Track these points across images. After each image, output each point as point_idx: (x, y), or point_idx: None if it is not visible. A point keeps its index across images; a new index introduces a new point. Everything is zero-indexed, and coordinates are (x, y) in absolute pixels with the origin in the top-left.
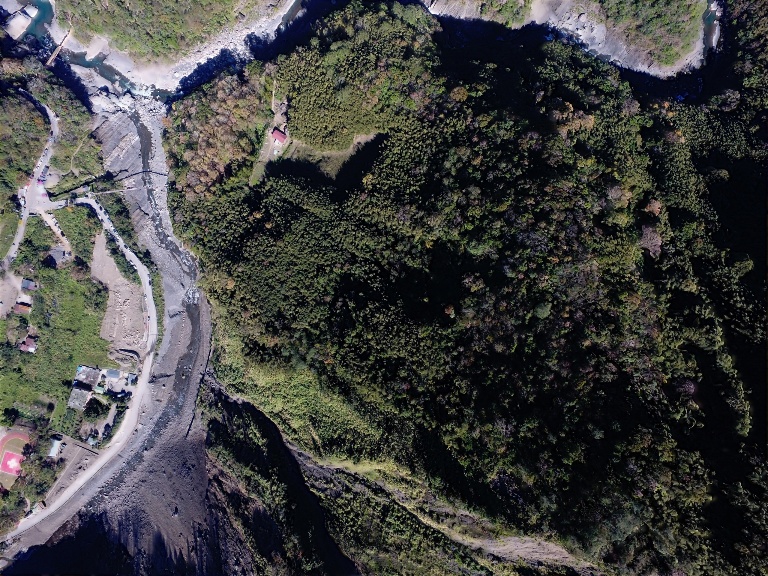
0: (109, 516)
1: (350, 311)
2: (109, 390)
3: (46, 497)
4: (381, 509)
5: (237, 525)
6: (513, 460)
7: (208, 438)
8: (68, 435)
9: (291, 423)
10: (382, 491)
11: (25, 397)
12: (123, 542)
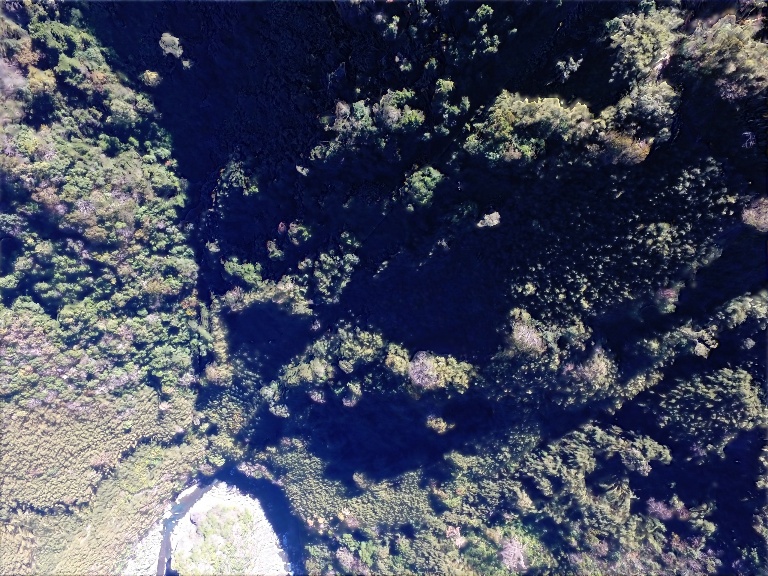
0: None
1: None
2: None
3: None
4: None
5: None
6: None
7: None
8: None
9: None
10: None
11: None
12: None
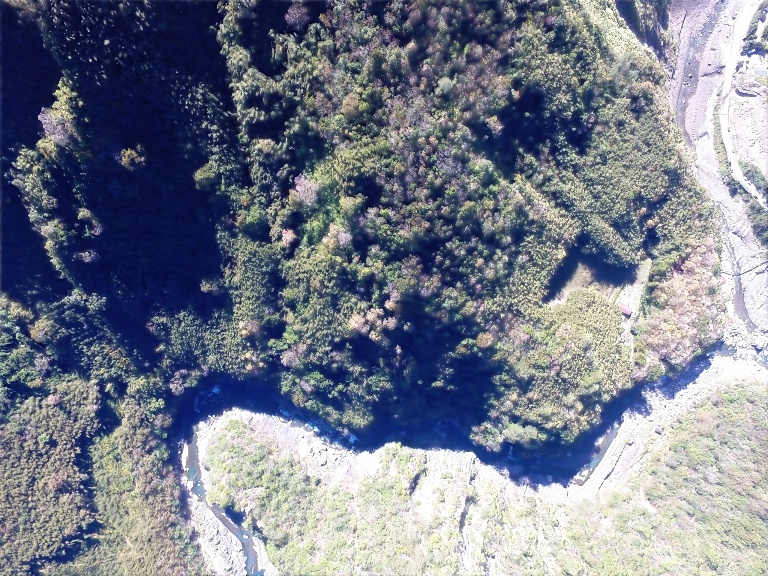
0: None
1: None
2: (763, 56)
3: None
4: None
5: None
6: None
7: None
8: None
9: None
10: None
11: None
12: None
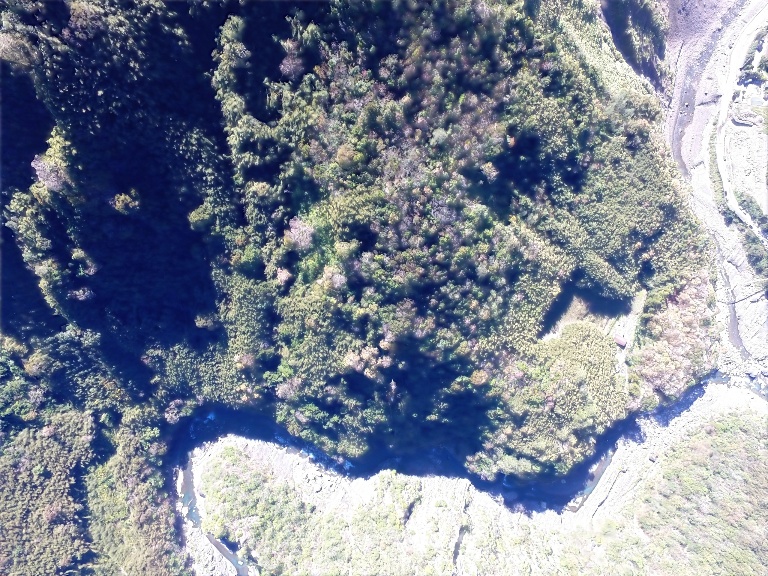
0: None
1: None
2: (760, 86)
3: None
4: None
5: None
6: None
7: None
8: None
9: None
10: None
11: None
12: None
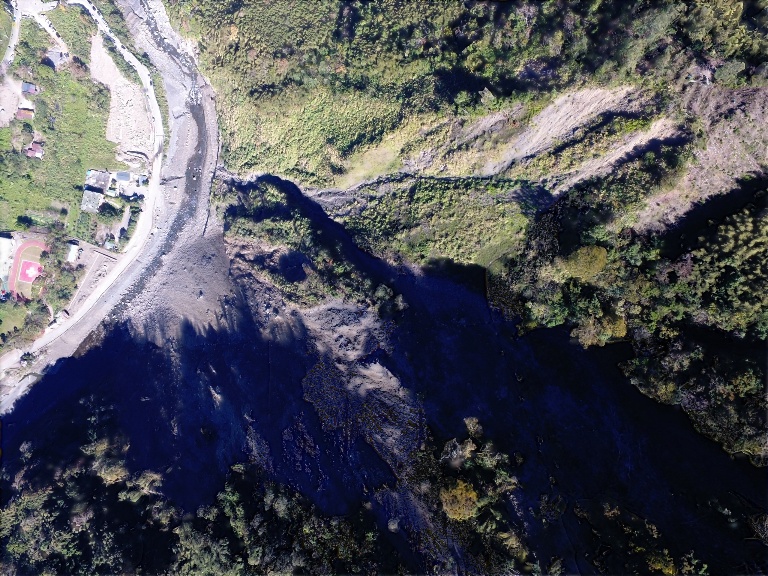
0: (134, 322)
1: (358, 11)
2: (121, 194)
3: (68, 306)
4: (408, 193)
5: (264, 276)
6: (538, 44)
7: (225, 229)
8: (84, 240)
9: (308, 166)
10: (407, 175)
11: (37, 204)
12: (150, 340)
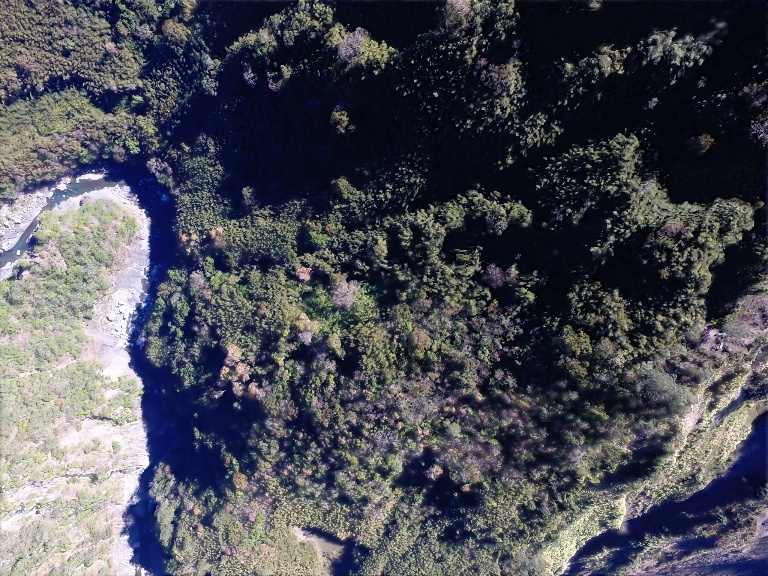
0: None
1: None
2: None
3: None
4: None
5: None
6: None
7: None
8: None
9: None
10: None
11: None
12: None
